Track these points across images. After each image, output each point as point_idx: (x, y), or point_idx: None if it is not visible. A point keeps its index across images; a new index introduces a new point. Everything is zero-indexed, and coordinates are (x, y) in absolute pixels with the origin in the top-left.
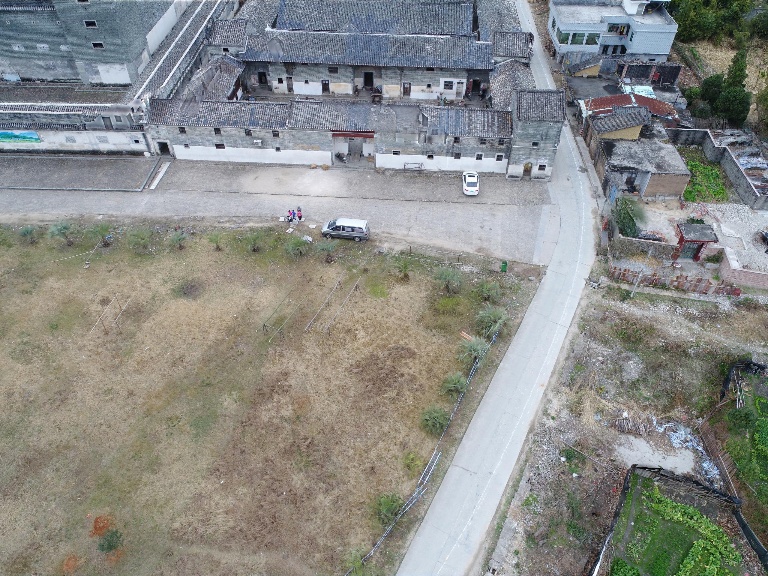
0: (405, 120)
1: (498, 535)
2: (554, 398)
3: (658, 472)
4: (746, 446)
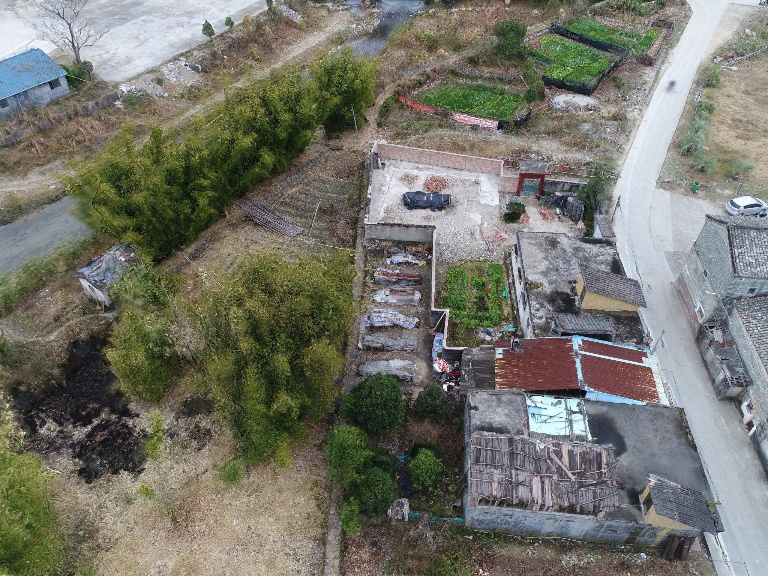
0: None
1: (656, 77)
2: (637, 115)
3: (580, 86)
4: (536, 82)
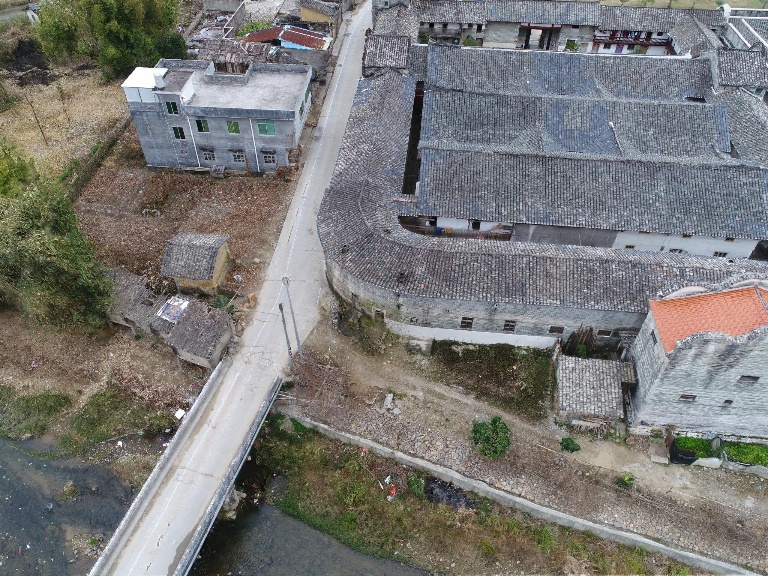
0: (497, 30)
1: None
2: None
3: None
4: None
